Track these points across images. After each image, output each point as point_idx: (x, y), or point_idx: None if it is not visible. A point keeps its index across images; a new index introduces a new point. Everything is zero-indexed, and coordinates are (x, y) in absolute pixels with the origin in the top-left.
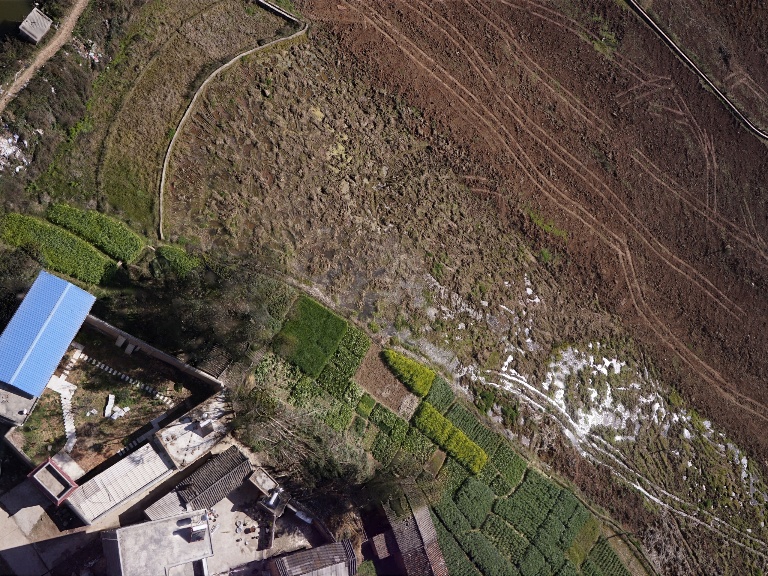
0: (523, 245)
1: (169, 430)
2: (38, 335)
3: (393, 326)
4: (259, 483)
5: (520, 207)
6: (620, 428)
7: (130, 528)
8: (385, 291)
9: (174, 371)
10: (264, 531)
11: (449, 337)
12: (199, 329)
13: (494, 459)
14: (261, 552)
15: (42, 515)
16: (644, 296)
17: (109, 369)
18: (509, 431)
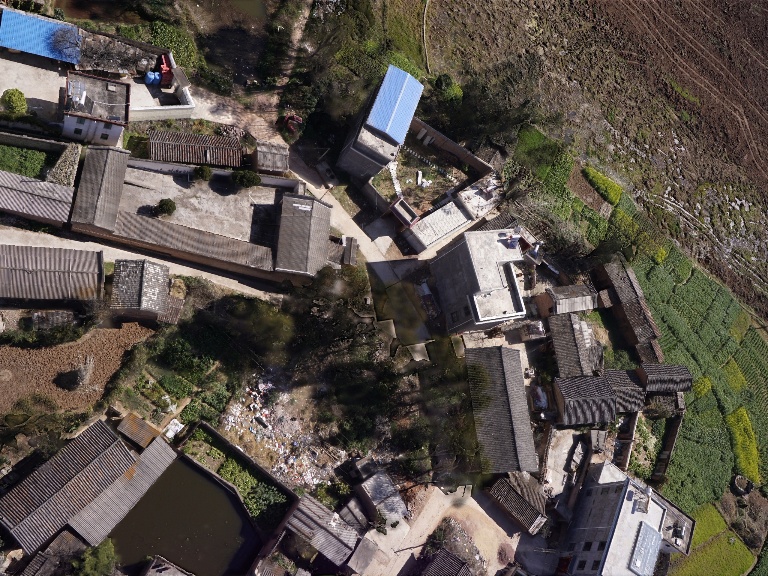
0: (668, 107)
1: (465, 193)
2: (397, 104)
3: (586, 154)
4: (525, 238)
5: (663, 77)
6: (754, 251)
7: (472, 233)
8: (577, 128)
9: (457, 159)
10: (527, 277)
11: (625, 167)
12: (486, 116)
13: (669, 257)
14: (527, 292)
15: (391, 243)
16: (761, 154)
17: (415, 154)
18: (676, 240)
